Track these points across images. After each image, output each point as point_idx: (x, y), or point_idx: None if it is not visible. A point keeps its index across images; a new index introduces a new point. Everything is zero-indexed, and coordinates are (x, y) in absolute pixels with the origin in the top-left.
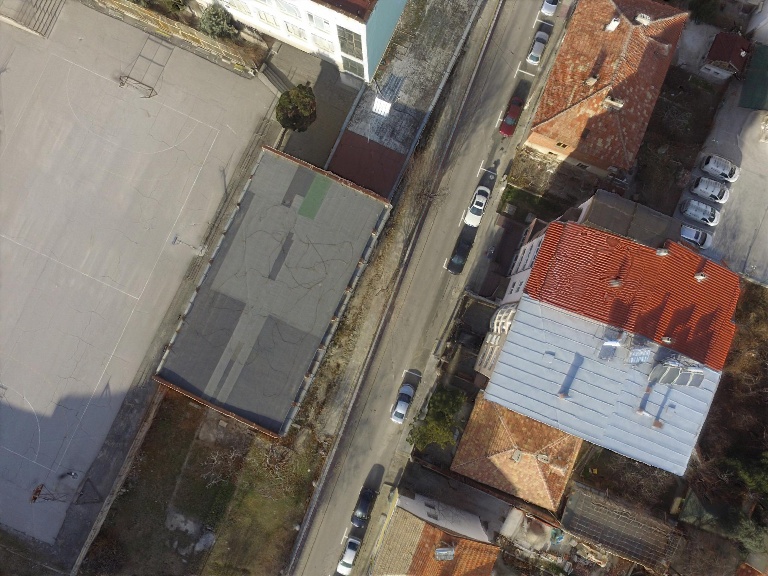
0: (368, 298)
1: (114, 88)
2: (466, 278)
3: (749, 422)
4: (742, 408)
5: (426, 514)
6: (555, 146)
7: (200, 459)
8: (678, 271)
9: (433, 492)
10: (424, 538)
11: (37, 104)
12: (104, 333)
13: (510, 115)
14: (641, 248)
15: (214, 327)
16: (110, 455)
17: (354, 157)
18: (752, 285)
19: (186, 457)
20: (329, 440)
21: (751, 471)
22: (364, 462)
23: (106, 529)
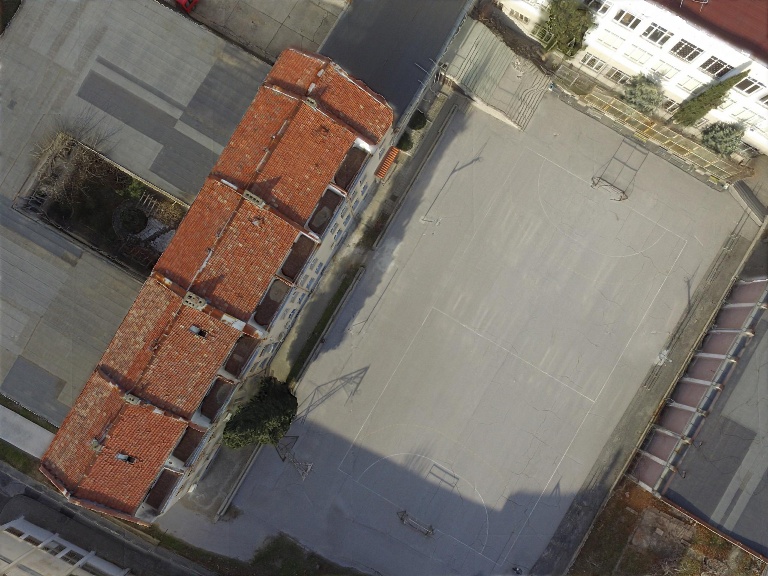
0: None
1: (585, 188)
2: None
3: None
4: None
5: None
6: None
7: (632, 564)
8: None
9: None
10: None
11: (507, 196)
12: (558, 433)
13: None
14: None
15: (723, 454)
16: (555, 554)
17: None
18: None
19: (618, 560)
20: None
21: None
22: None
23: None
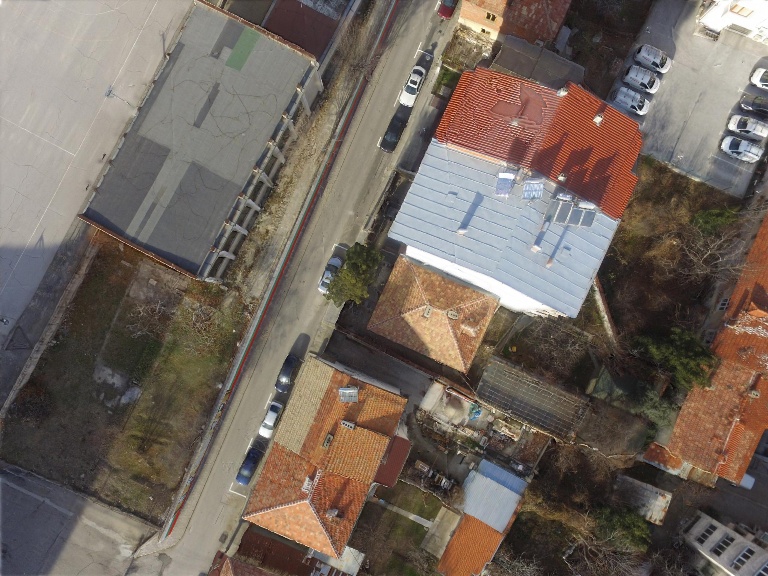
0: (299, 167)
1: None
2: (398, 157)
3: (663, 303)
4: (658, 290)
5: (341, 370)
6: (485, 19)
7: None
8: (577, 113)
9: (357, 363)
10: (333, 384)
11: None
12: (40, 187)
13: None
14: (543, 90)
15: (139, 171)
16: (41, 304)
17: (287, 20)
18: (678, 176)
19: (116, 313)
20: (255, 302)
21: (659, 345)
22: (291, 331)
23: (36, 378)
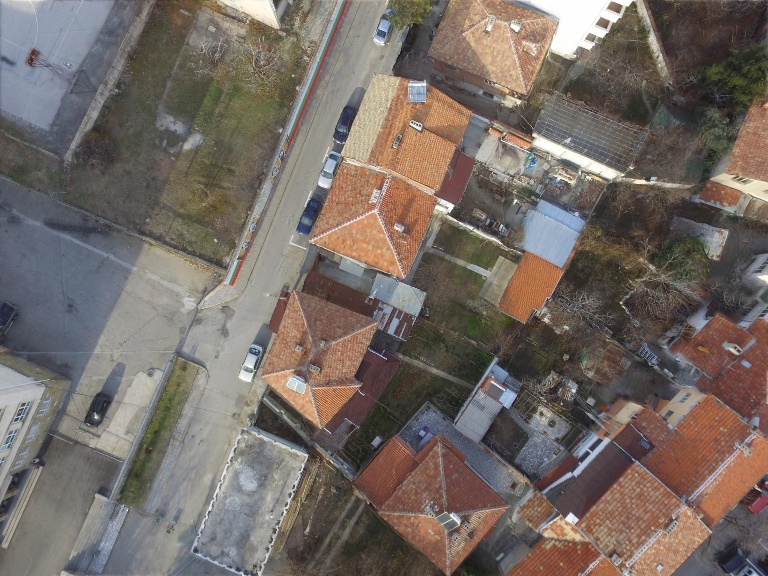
0: None
1: None
2: None
3: (719, 34)
4: (713, 25)
5: None
6: None
7: None
8: None
9: None
10: (399, 91)
11: None
12: None
13: None
14: None
15: None
16: (104, 48)
17: None
18: None
19: (176, 61)
20: (313, 46)
21: None
22: (347, 85)
23: (99, 125)
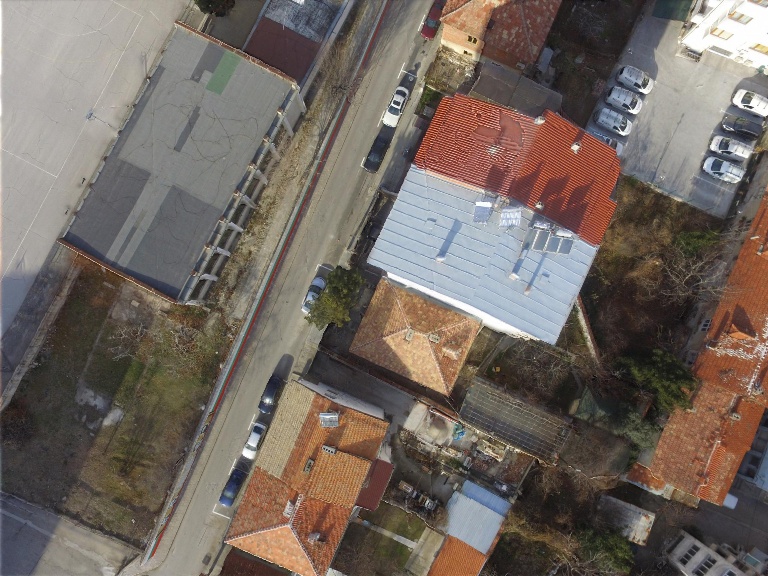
0: (282, 188)
1: None
2: (382, 177)
3: (646, 324)
4: (641, 311)
5: (323, 393)
6: (467, 42)
7: None
8: (555, 141)
9: (340, 384)
10: (314, 408)
11: None
12: (21, 208)
13: (431, 17)
14: (521, 118)
15: (119, 195)
16: (22, 327)
17: (269, 43)
18: (661, 196)
19: (98, 335)
20: (237, 324)
21: (641, 367)
22: (274, 352)
23: (17, 400)
